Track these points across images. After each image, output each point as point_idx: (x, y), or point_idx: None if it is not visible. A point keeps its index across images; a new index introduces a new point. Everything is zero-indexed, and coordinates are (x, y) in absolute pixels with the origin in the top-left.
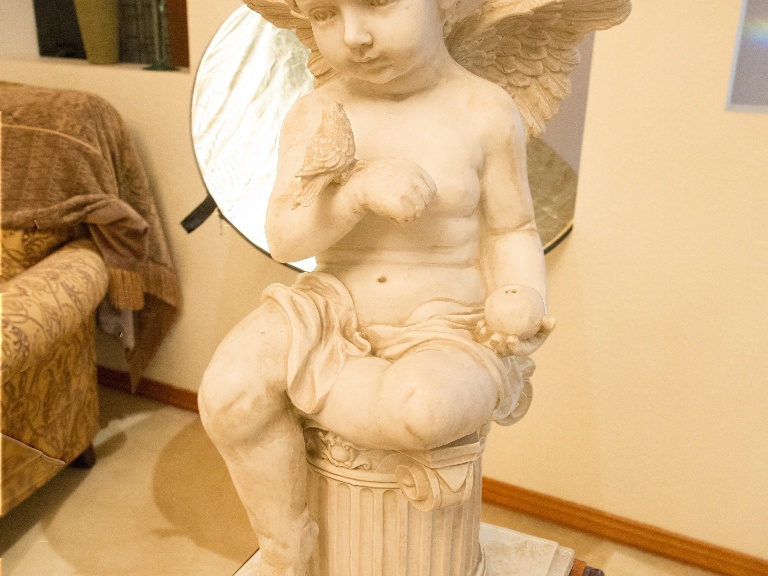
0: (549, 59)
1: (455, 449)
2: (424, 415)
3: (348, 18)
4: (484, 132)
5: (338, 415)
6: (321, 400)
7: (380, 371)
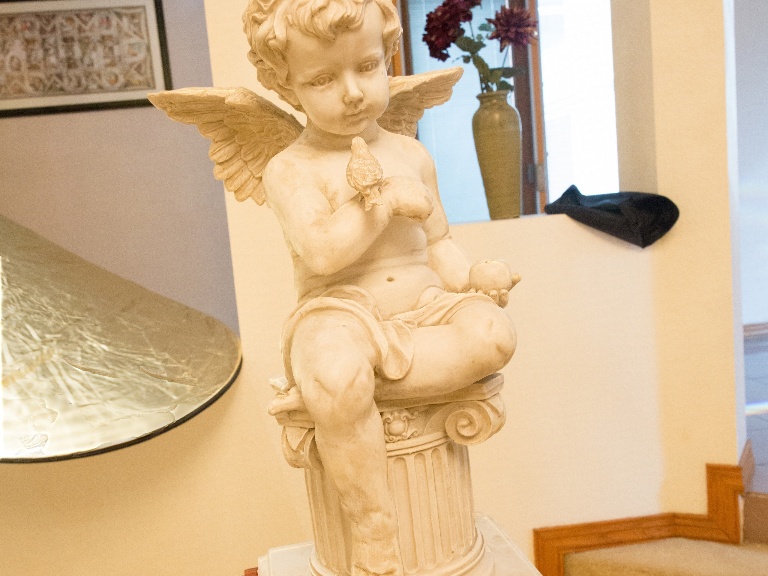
0: (404, 130)
1: (495, 380)
2: (506, 334)
3: (350, 80)
4: (421, 165)
5: (429, 368)
6: (411, 361)
7: (446, 326)
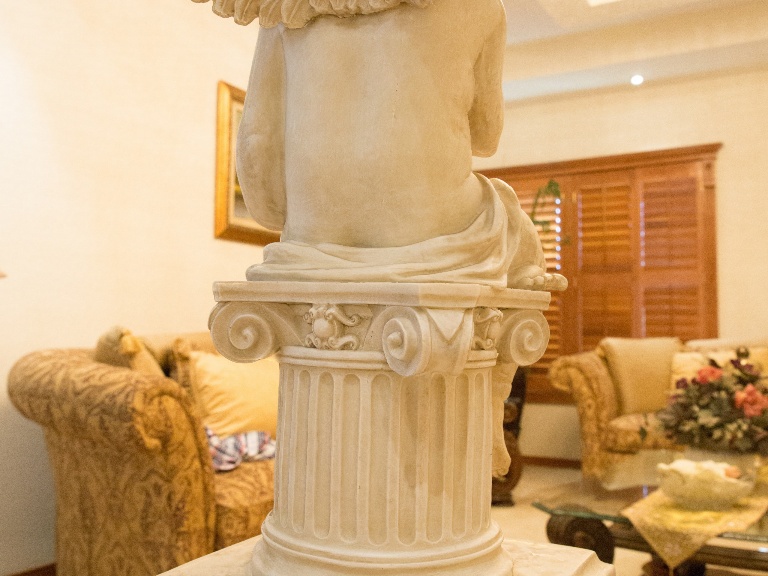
0: None
1: None
2: None
3: None
4: None
5: None
6: None
7: None
